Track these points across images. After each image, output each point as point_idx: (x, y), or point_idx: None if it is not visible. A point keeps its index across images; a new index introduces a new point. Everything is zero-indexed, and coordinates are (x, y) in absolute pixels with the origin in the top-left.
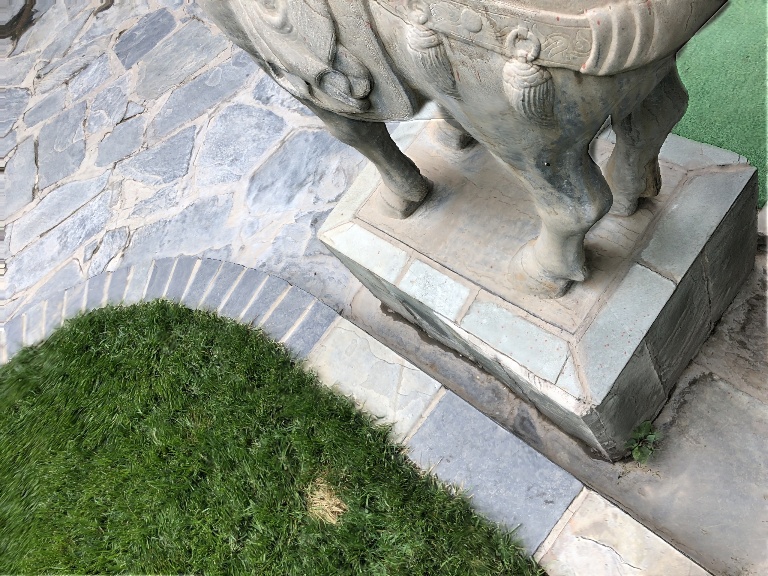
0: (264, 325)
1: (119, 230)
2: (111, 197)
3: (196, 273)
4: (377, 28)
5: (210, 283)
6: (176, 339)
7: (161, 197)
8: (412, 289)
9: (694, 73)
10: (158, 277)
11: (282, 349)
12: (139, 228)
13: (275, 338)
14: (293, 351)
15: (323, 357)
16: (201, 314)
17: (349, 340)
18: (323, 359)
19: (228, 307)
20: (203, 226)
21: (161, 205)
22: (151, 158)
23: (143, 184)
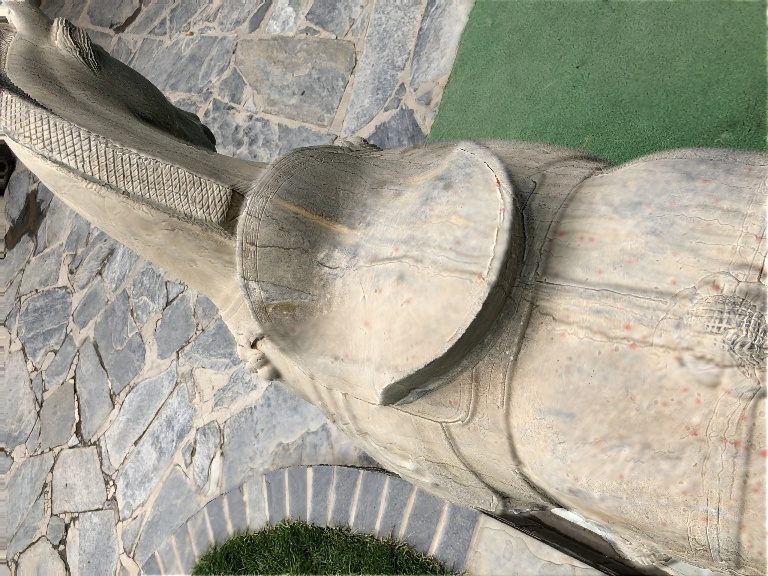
0: (405, 536)
1: (208, 427)
2: (187, 391)
3: (312, 484)
4: (550, 499)
5: (330, 494)
6: (319, 566)
7: (237, 382)
8: (568, 513)
9: (759, 134)
10: (274, 494)
11: (436, 566)
12: (227, 420)
13: (422, 551)
14: (447, 563)
15: (481, 565)
16: (335, 533)
17: (502, 542)
18: (482, 568)
19: (359, 520)
20: (290, 407)
21: (240, 391)
22: (211, 340)
23: (214, 370)
